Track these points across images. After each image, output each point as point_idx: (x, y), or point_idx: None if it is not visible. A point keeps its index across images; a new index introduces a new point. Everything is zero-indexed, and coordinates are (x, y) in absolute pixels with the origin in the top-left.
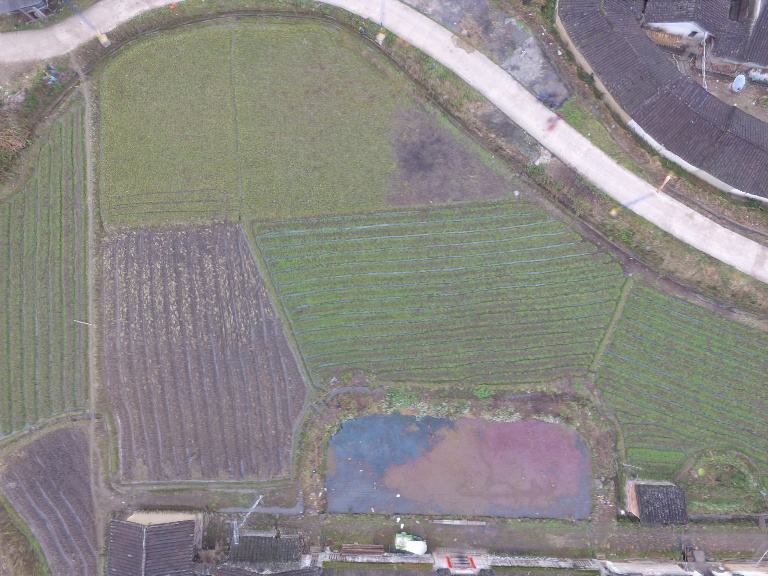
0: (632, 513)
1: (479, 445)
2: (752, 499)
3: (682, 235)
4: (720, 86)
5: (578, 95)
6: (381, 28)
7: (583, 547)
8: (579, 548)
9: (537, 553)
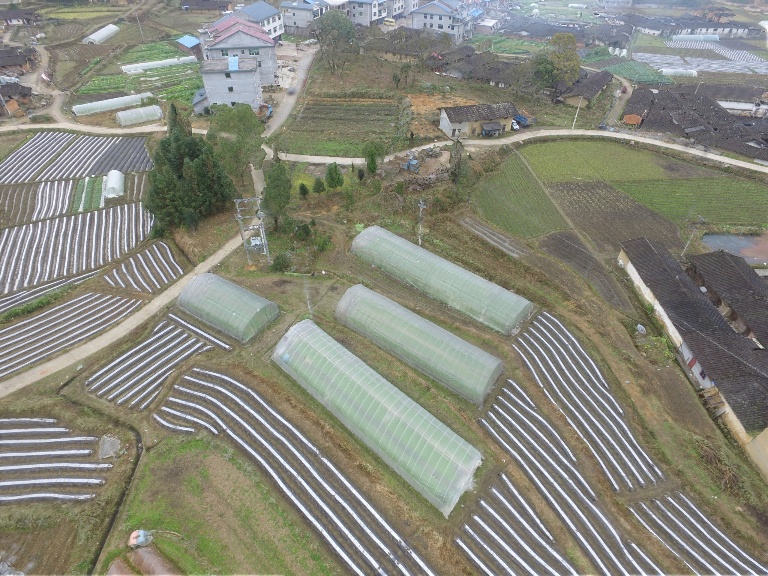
0: None
1: None
2: None
3: None
4: None
5: None
6: None
7: None
8: None
9: None
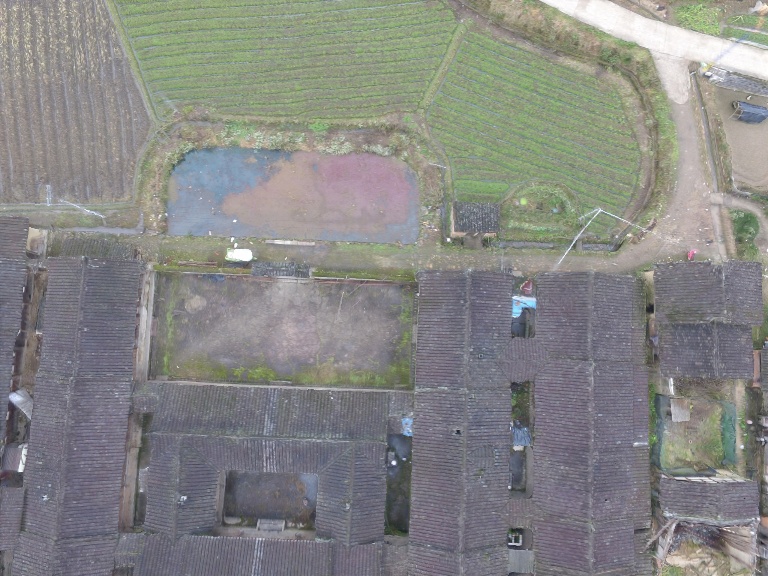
0: (456, 237)
1: (313, 176)
2: (570, 225)
3: None
4: None
5: None
6: None
7: (407, 267)
8: (403, 268)
9: (363, 271)
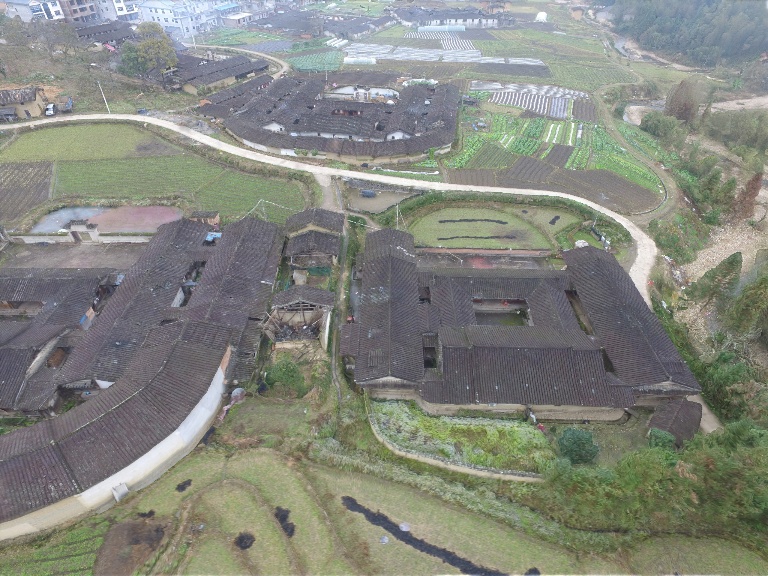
0: None
1: (126, 213)
2: None
3: (249, 157)
4: None
5: None
6: None
7: None
8: None
9: None
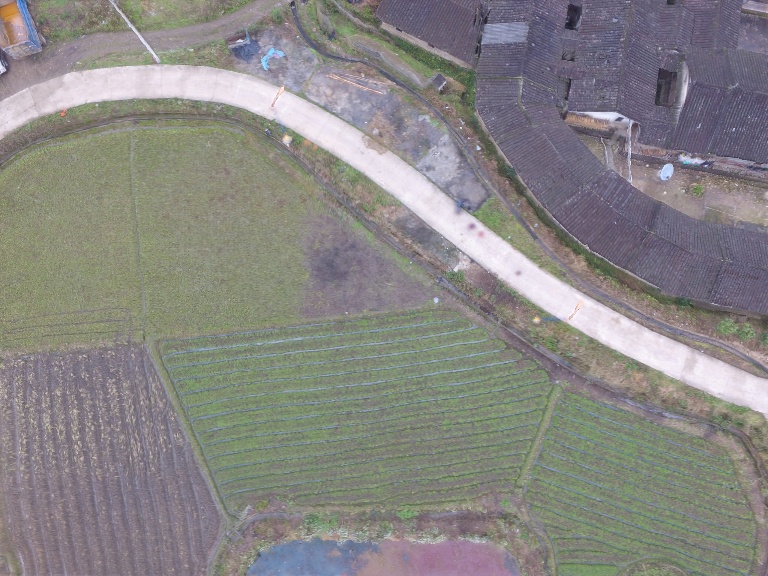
0: None
1: (404, 568)
2: None
3: (608, 341)
4: (649, 173)
5: (499, 192)
6: (286, 133)
7: None
8: None
9: None
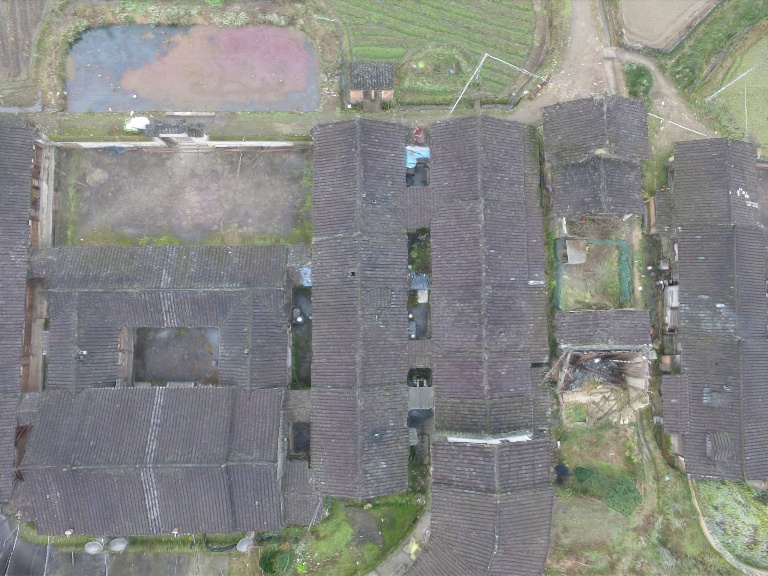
0: (355, 102)
1: (212, 49)
2: None
3: None
4: None
5: None
6: None
7: (308, 133)
8: (304, 134)
9: None
